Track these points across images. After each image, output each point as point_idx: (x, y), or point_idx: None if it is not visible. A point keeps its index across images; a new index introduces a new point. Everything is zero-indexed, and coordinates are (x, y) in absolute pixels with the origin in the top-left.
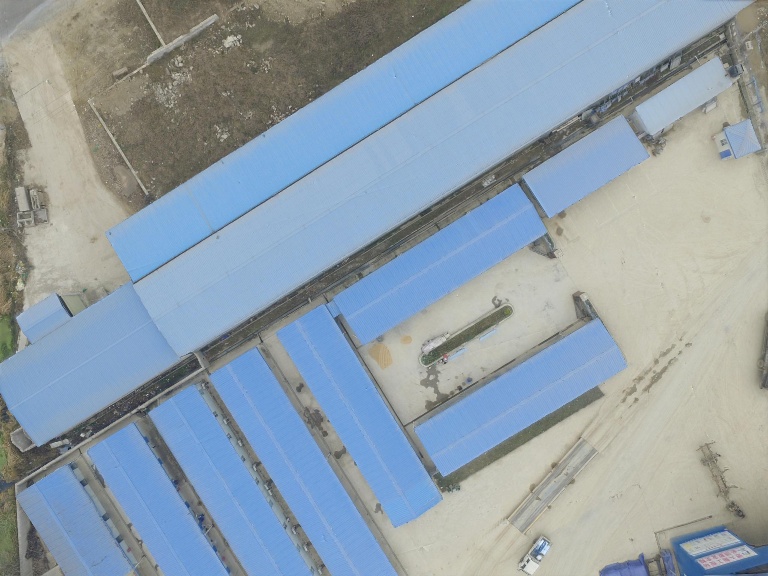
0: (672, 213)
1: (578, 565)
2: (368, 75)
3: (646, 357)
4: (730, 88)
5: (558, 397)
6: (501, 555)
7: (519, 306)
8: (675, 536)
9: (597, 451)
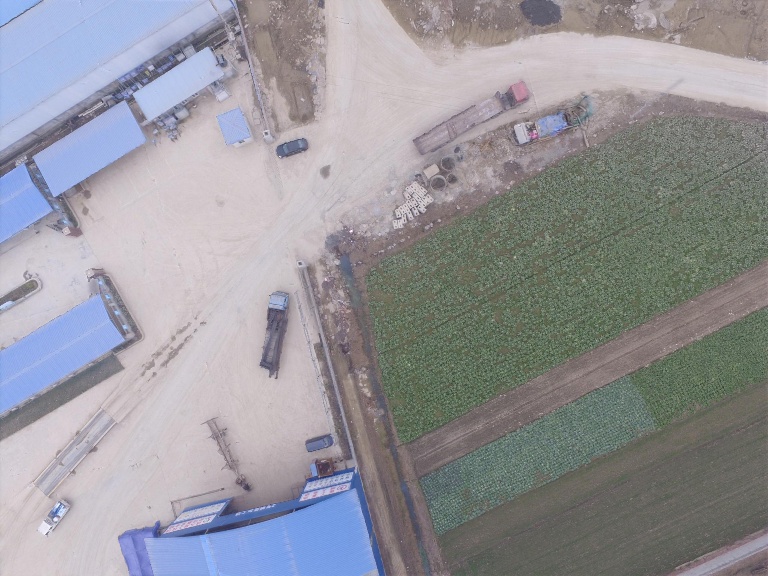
0: (189, 197)
1: (100, 529)
2: None
3: (164, 334)
4: (243, 78)
5: (59, 367)
6: (29, 516)
7: (48, 281)
8: (189, 506)
9: (115, 421)
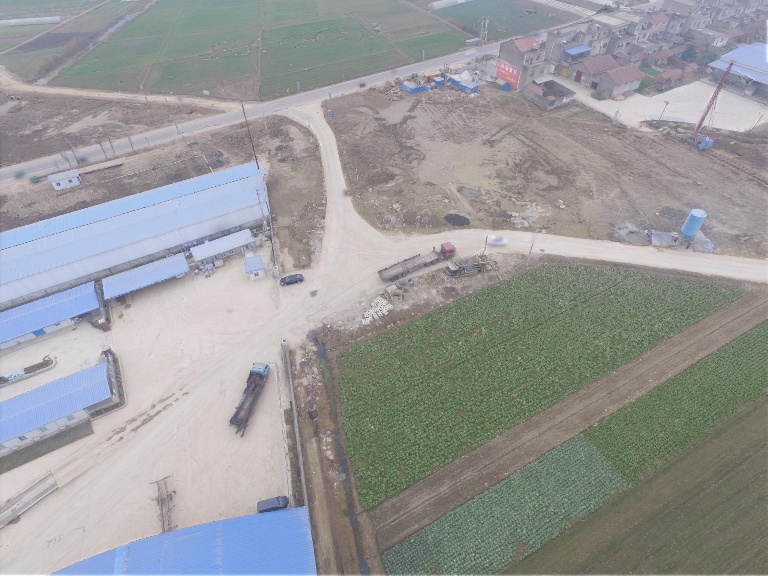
0: (206, 307)
1: None
2: (29, 227)
3: (146, 402)
4: (266, 248)
5: (36, 419)
6: None
7: (62, 362)
8: None
9: (57, 485)
